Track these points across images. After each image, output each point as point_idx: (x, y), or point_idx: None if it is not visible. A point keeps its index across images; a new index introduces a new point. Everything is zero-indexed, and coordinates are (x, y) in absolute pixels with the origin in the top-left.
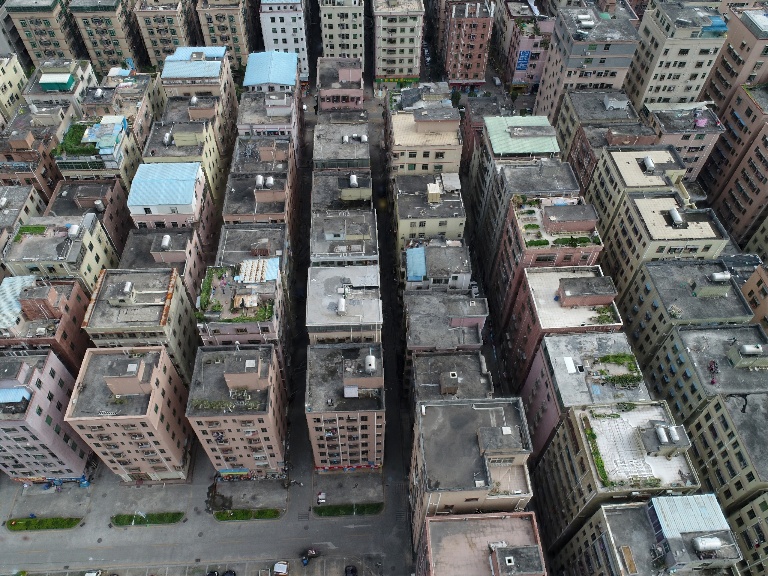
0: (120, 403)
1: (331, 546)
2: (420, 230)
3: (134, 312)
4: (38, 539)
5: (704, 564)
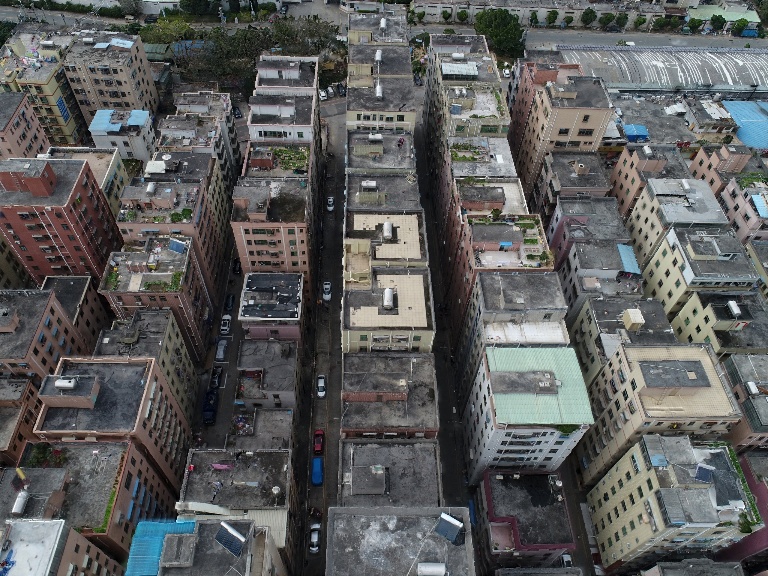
0: None
1: None
2: None
3: None
4: None
5: None
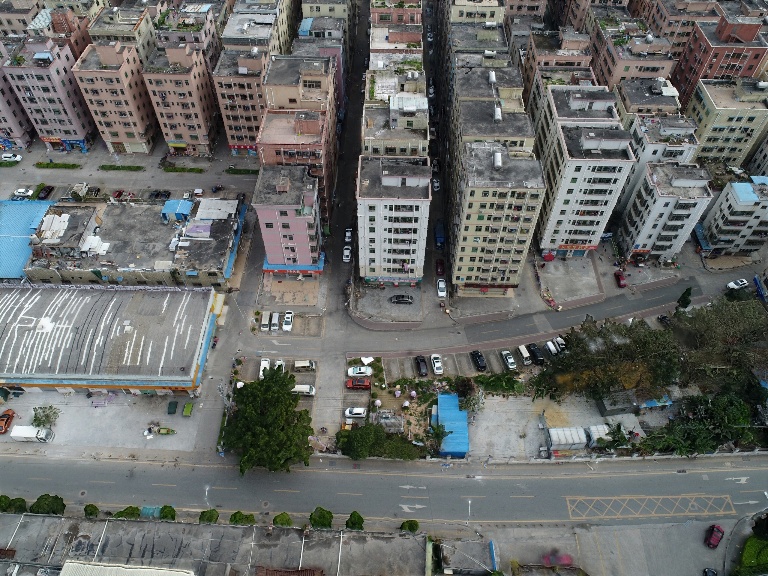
0: (105, 68)
1: (232, 186)
2: (317, 15)
3: (118, 26)
4: (54, 172)
5: (410, 124)
